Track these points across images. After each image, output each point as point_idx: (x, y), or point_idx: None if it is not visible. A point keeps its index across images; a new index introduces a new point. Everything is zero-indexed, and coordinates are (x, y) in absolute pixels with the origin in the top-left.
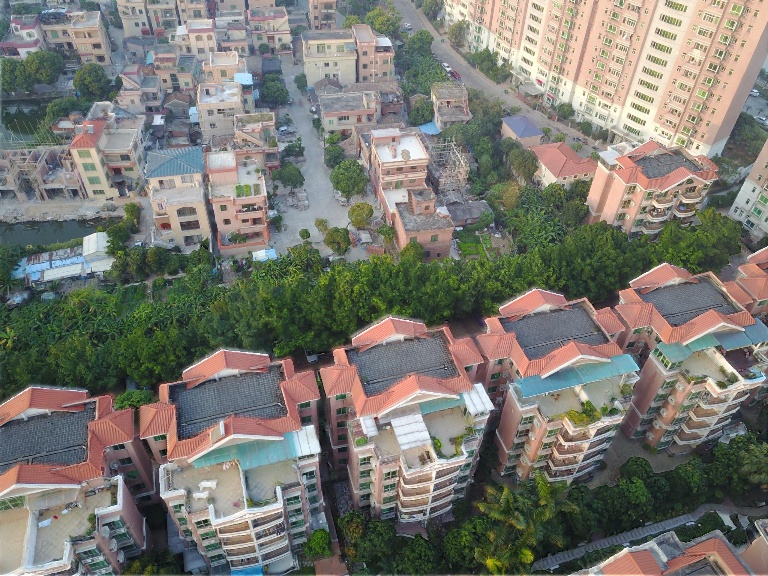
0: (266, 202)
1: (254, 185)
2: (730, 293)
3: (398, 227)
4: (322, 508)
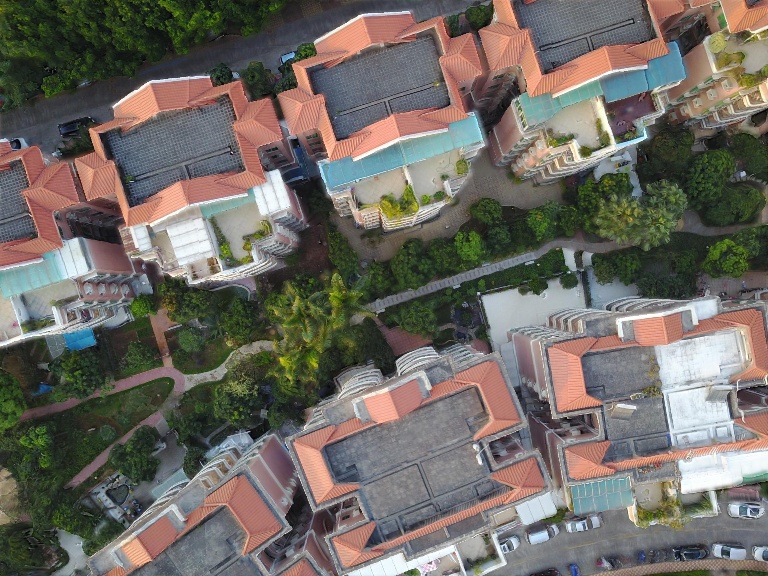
0: None
1: None
2: (651, 2)
3: None
4: (141, 272)
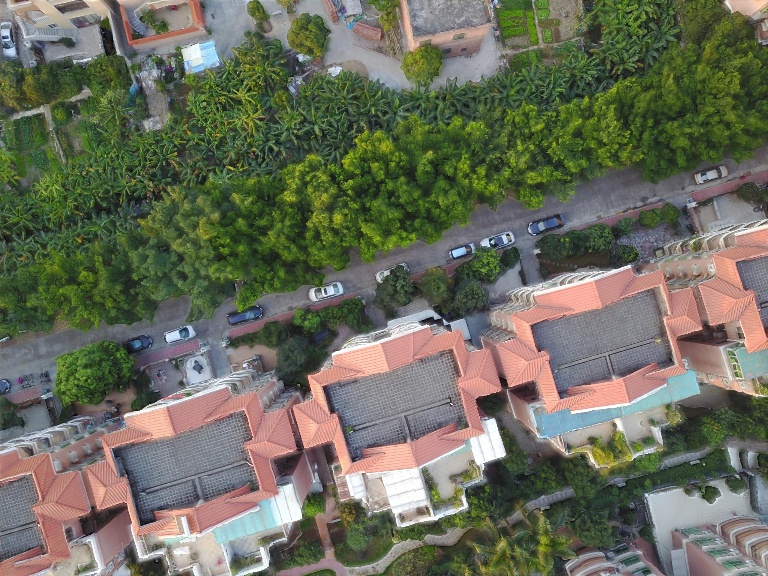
0: None
1: None
2: None
3: (402, 2)
4: None
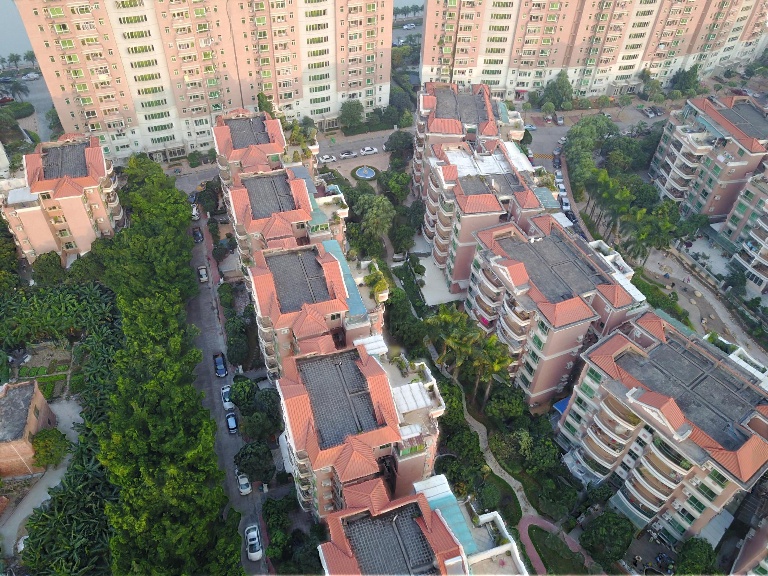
0: None
1: None
2: (264, 171)
3: None
4: None
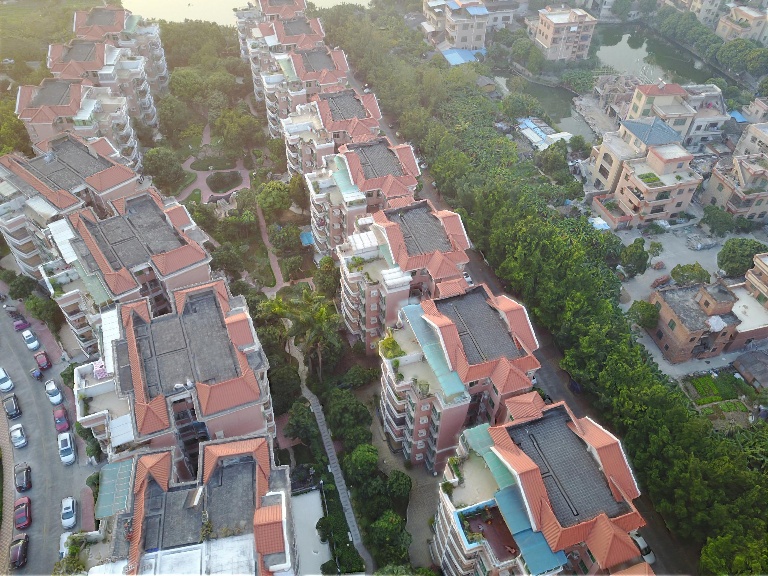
0: (653, 201)
1: (661, 182)
2: (597, 523)
3: None
4: None
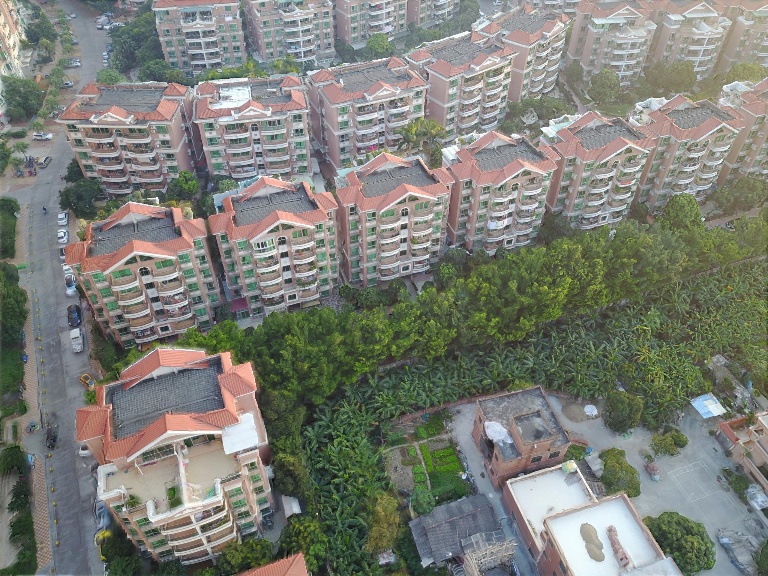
0: (763, 447)
1: None
2: None
3: None
4: None
